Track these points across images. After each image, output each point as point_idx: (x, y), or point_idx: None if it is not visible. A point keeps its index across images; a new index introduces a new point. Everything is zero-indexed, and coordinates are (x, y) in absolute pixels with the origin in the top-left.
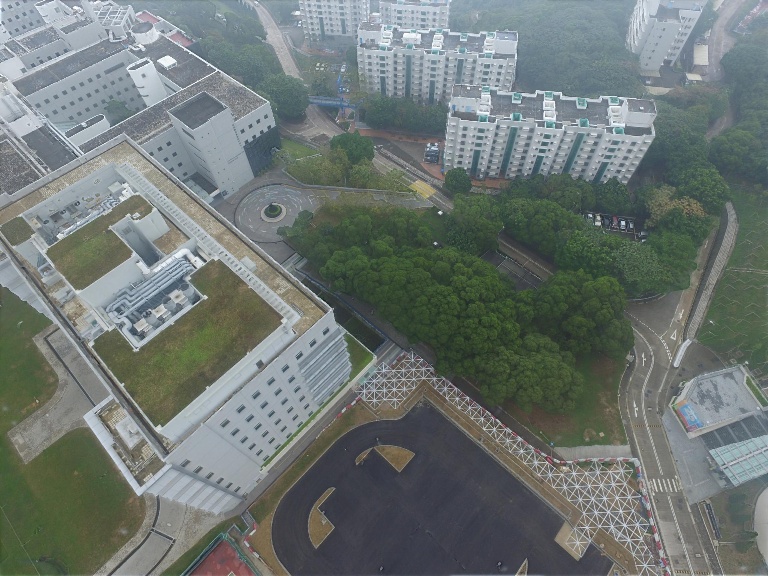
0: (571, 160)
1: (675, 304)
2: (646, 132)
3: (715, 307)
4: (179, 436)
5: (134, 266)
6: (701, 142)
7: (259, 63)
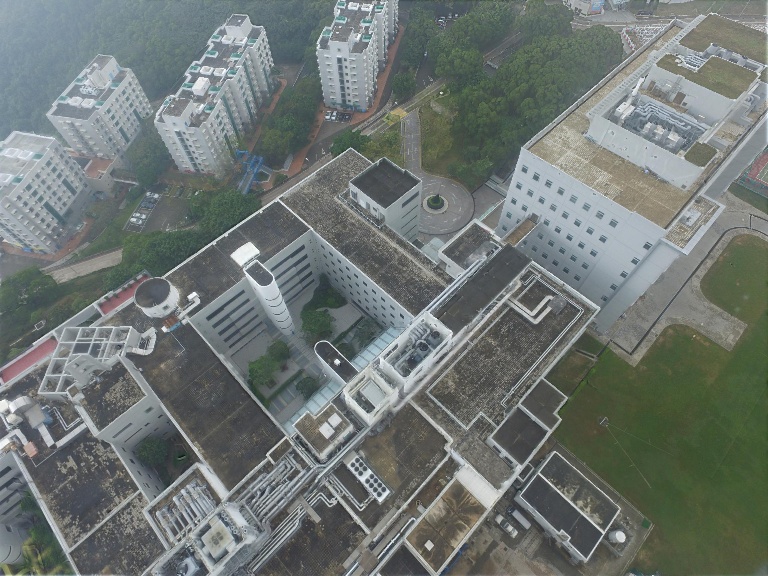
0: None
1: None
2: None
3: None
4: None
5: None
6: None
7: None
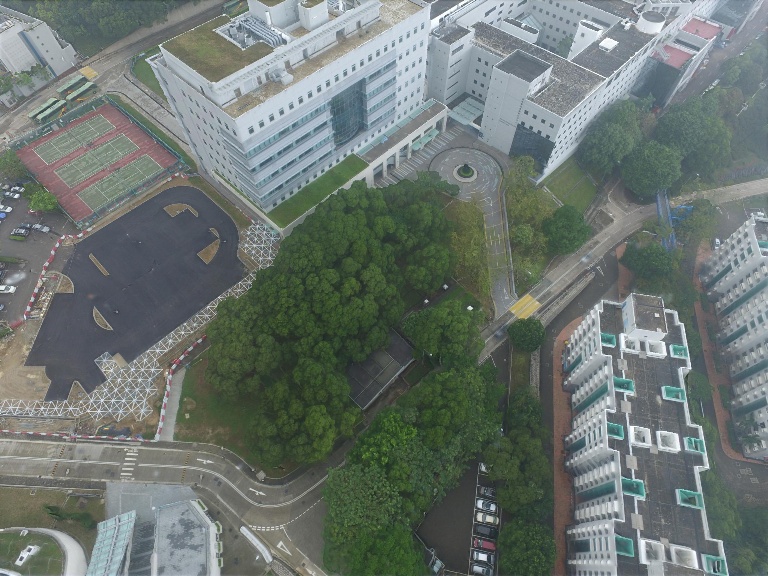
0: (595, 495)
1: (330, 572)
2: None
3: None
4: None
5: None
6: None
7: (690, 135)
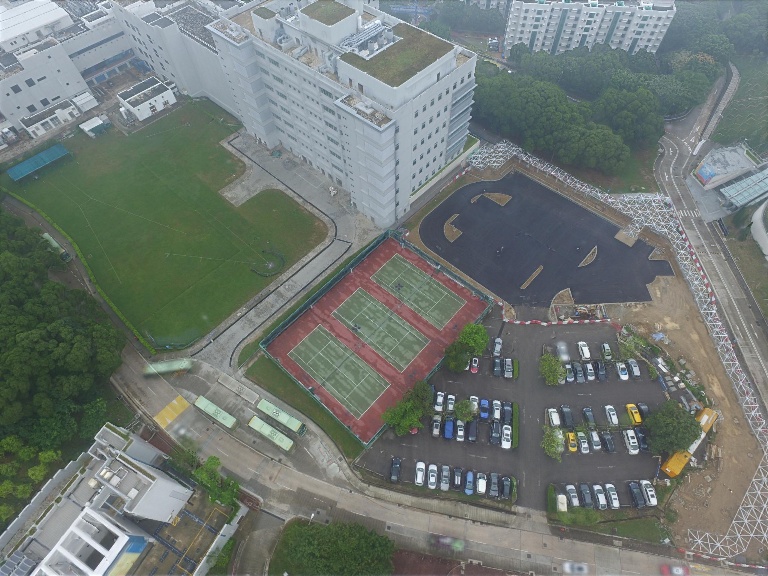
0: (608, 39)
1: (693, 123)
2: (669, 10)
3: (723, 122)
4: (397, 107)
5: (355, 20)
6: (711, 21)
7: None
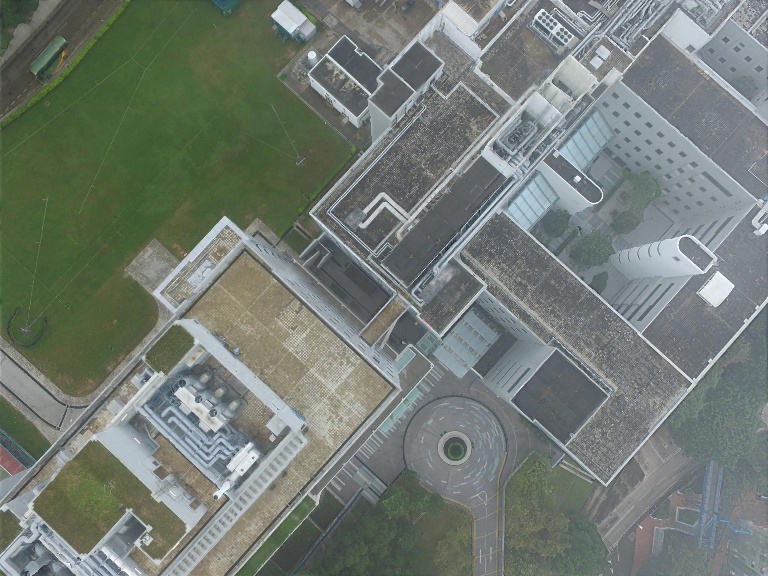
0: None
1: None
2: None
3: None
4: None
5: None
6: None
7: None
